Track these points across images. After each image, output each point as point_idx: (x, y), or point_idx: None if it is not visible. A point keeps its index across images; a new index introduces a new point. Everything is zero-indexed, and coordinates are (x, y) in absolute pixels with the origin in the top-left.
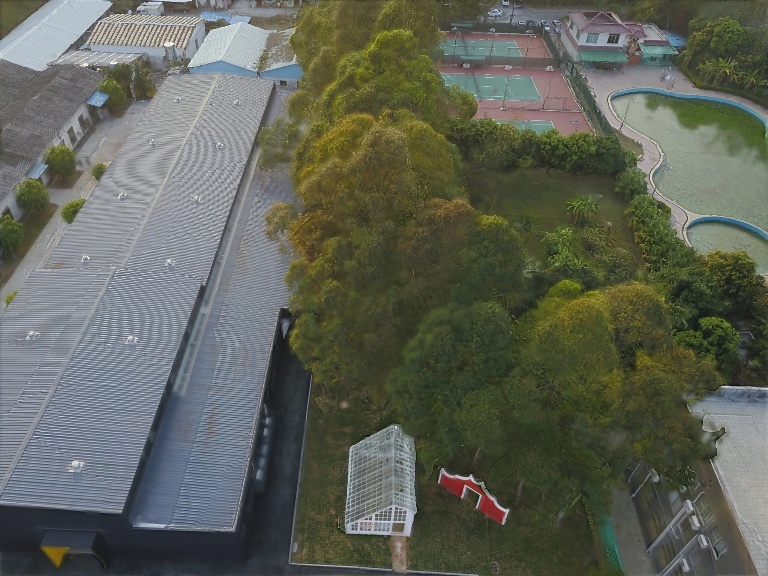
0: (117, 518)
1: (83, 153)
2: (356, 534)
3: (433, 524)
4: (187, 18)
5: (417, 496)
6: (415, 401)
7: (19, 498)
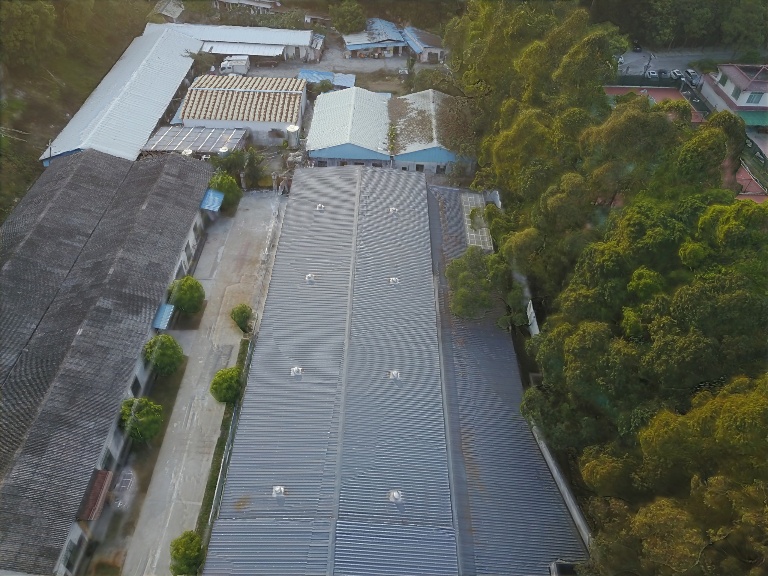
0: None
1: (201, 273)
2: None
3: None
4: (287, 80)
5: None
6: None
7: None
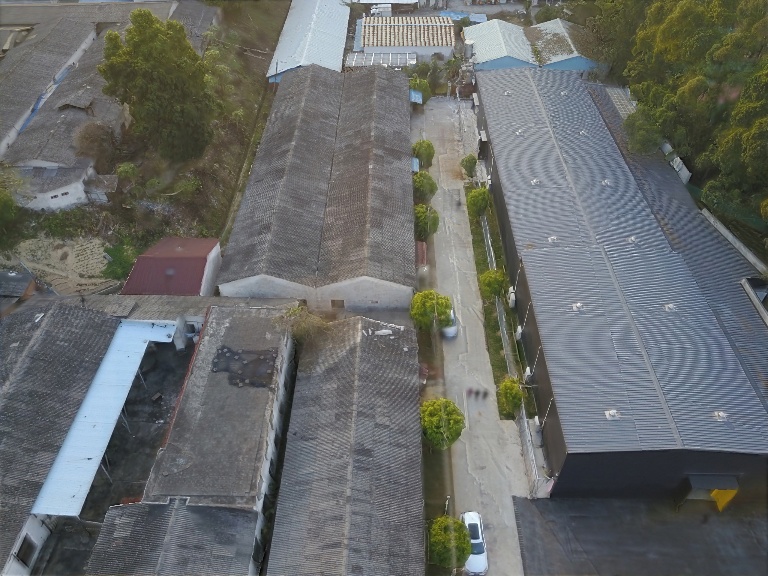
0: None
1: None
2: None
3: None
4: (436, 18)
5: None
6: None
7: (699, 444)
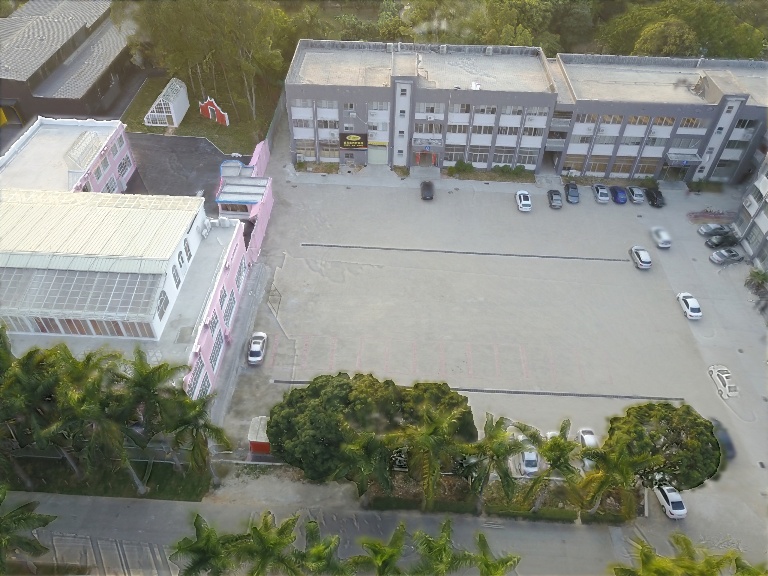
0: (24, 86)
1: None
2: (150, 125)
3: (192, 125)
4: None
5: (188, 117)
6: (147, 15)
7: None
